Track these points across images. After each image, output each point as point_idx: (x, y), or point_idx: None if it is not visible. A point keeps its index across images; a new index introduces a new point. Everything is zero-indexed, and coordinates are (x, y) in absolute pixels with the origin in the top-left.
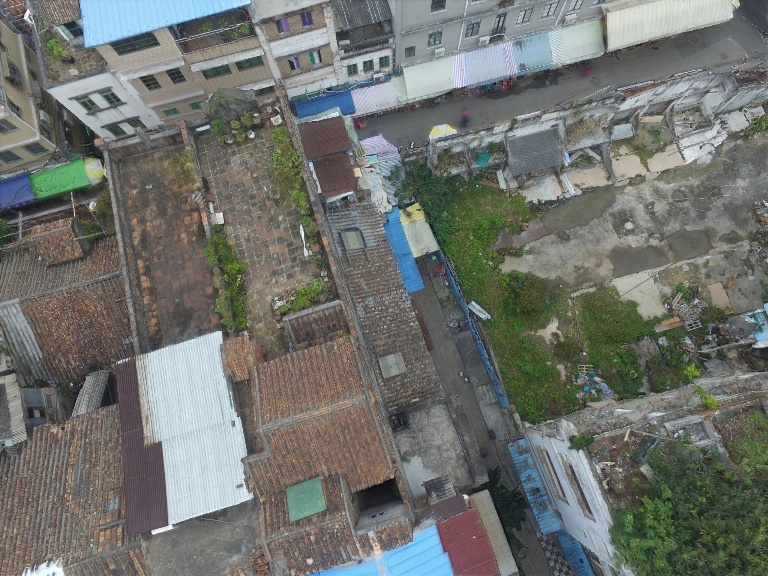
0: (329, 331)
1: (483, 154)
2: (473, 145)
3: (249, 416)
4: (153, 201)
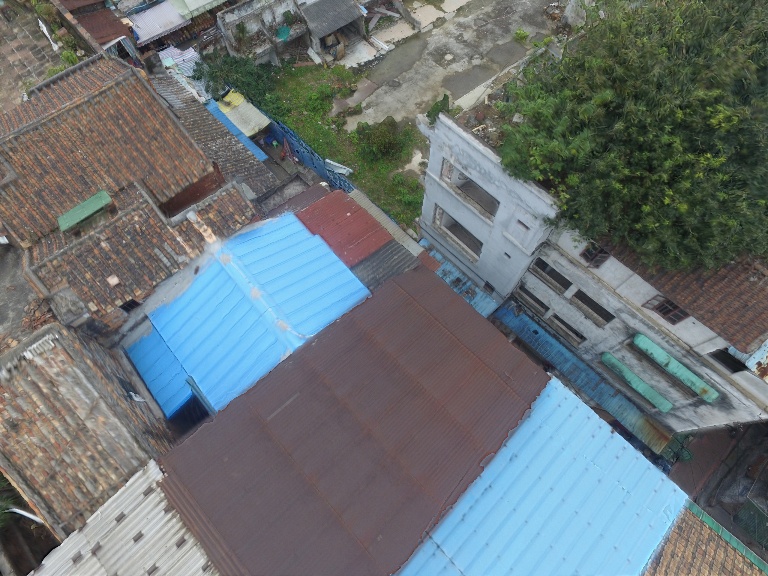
0: None
1: (282, 28)
2: (267, 20)
3: None
4: None
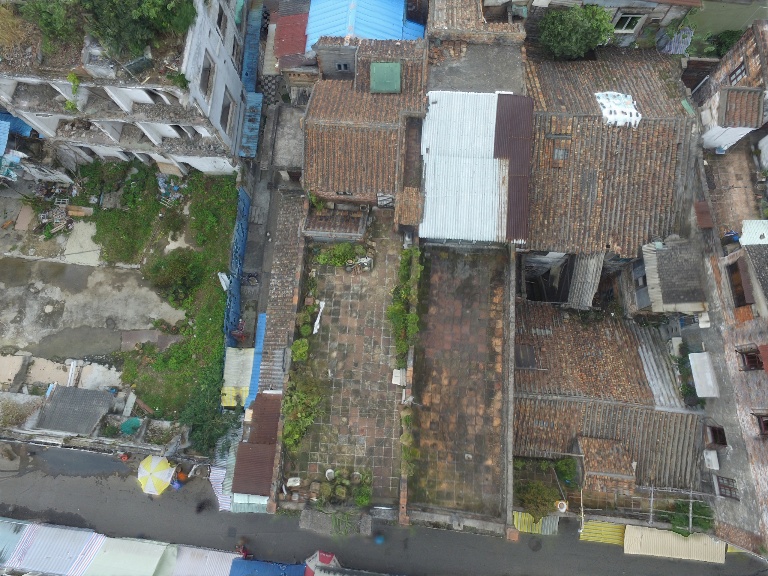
0: (328, 218)
1: (126, 431)
2: None
3: (416, 160)
4: (470, 440)
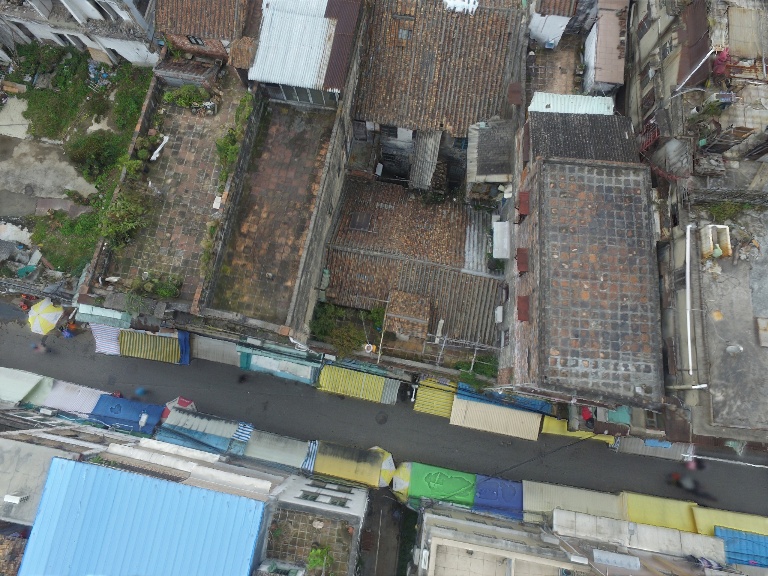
0: None
1: (22, 275)
2: None
3: None
4: (276, 264)
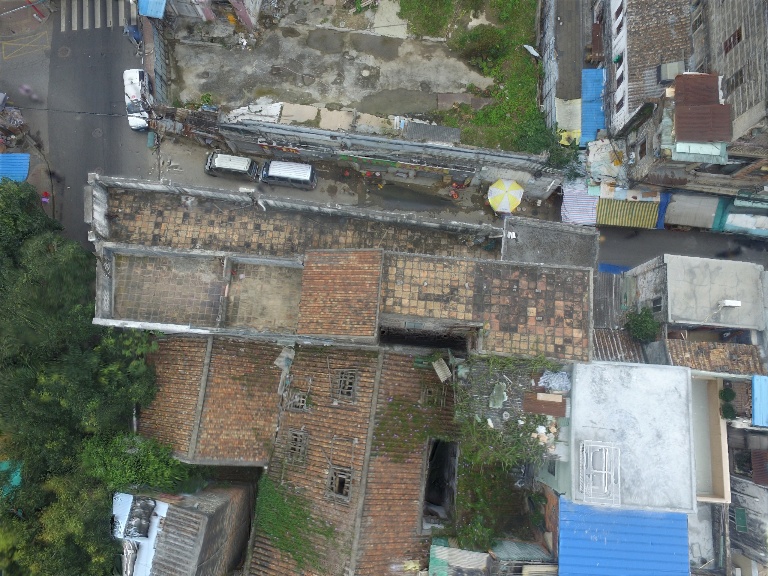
0: None
1: None
2: None
3: None
4: None
